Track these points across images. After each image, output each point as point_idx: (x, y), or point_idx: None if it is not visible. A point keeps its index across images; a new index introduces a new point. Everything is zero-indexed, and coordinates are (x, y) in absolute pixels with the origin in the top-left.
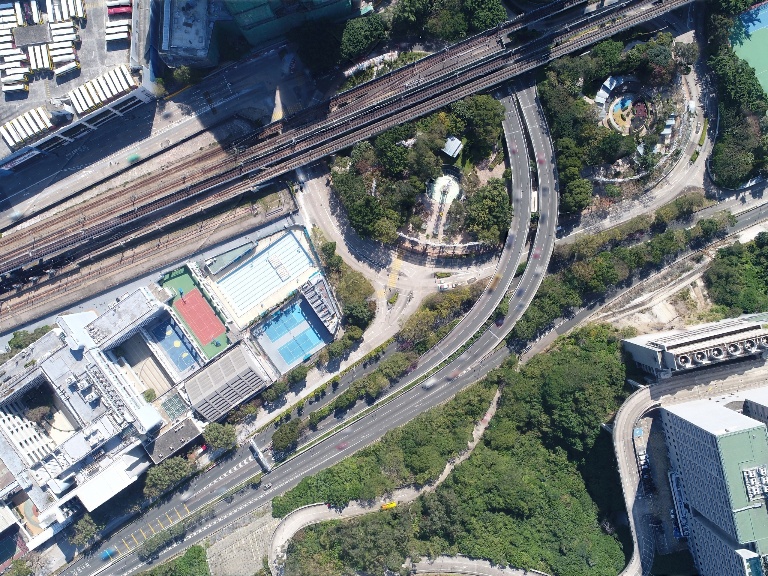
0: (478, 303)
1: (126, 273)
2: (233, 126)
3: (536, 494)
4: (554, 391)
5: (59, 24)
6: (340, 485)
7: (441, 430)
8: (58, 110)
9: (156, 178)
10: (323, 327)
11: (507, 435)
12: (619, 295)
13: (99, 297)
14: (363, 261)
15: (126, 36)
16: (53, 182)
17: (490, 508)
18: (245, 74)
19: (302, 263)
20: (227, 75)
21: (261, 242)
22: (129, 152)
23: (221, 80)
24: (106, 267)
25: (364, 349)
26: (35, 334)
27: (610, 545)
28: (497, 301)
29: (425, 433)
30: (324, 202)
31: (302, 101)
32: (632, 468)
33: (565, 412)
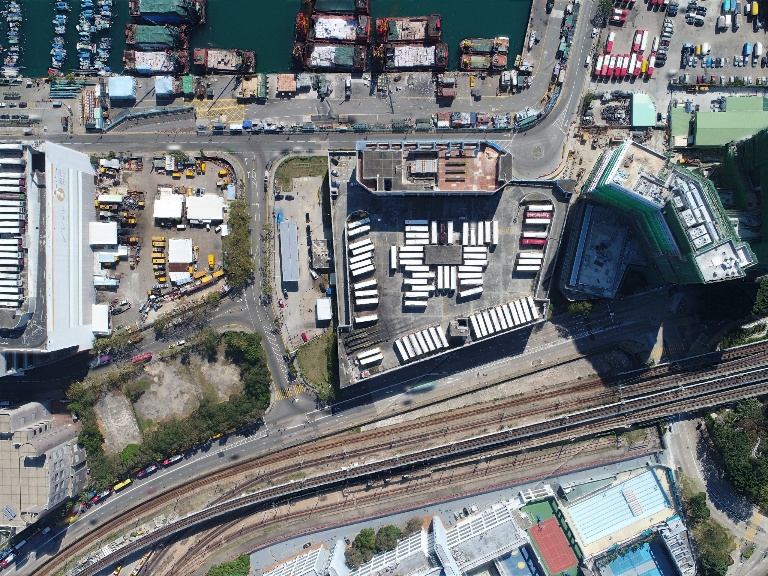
0: None
1: (477, 484)
2: (613, 358)
3: None
4: None
5: (472, 248)
6: None
7: None
8: (462, 335)
9: (528, 400)
10: (669, 569)
11: None
12: None
13: (446, 503)
14: (722, 510)
15: (538, 269)
16: (418, 384)
17: None
18: (630, 306)
19: (657, 501)
20: (611, 304)
21: (620, 475)
22: (499, 366)
23: (604, 308)
24: (458, 475)
25: None
26: (391, 541)
27: None
28: None
29: None
30: (691, 445)
31: (685, 341)
32: None
33: None
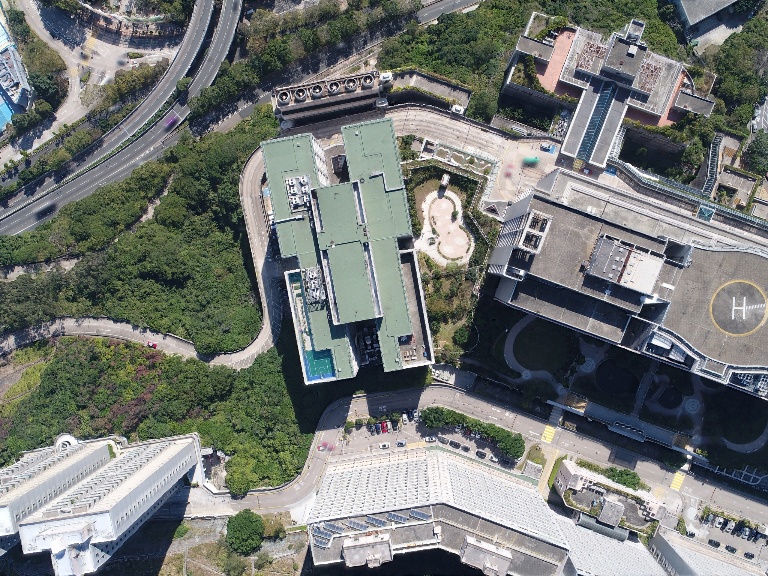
0: (162, 81)
1: None
2: None
3: (189, 265)
4: (213, 161)
5: None
6: (7, 250)
7: (114, 205)
8: None
9: None
10: None
11: (172, 209)
12: (305, 81)
13: None
14: (58, 38)
15: None
16: None
17: (138, 273)
18: None
19: (0, 38)
20: None
21: None
22: None
23: None
24: None
25: (57, 128)
26: None
27: (249, 314)
28: (180, 79)
29: (96, 205)
30: None
31: None
32: (261, 228)
33: (225, 185)
